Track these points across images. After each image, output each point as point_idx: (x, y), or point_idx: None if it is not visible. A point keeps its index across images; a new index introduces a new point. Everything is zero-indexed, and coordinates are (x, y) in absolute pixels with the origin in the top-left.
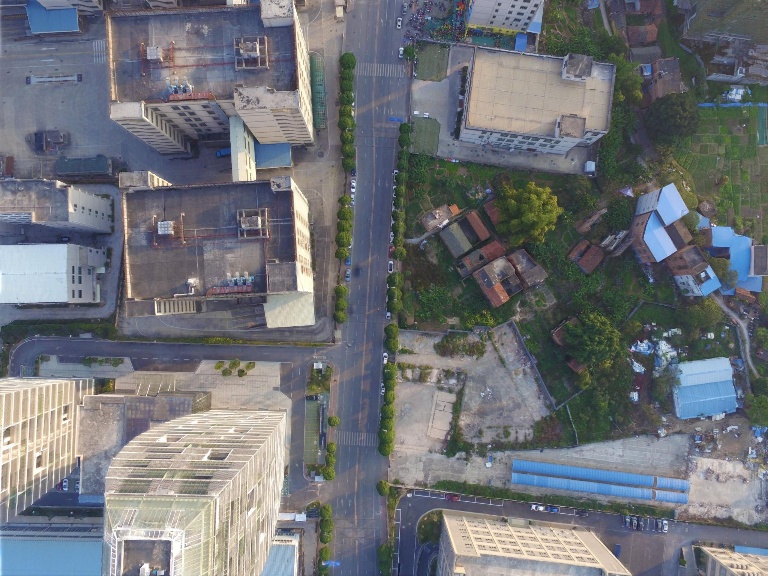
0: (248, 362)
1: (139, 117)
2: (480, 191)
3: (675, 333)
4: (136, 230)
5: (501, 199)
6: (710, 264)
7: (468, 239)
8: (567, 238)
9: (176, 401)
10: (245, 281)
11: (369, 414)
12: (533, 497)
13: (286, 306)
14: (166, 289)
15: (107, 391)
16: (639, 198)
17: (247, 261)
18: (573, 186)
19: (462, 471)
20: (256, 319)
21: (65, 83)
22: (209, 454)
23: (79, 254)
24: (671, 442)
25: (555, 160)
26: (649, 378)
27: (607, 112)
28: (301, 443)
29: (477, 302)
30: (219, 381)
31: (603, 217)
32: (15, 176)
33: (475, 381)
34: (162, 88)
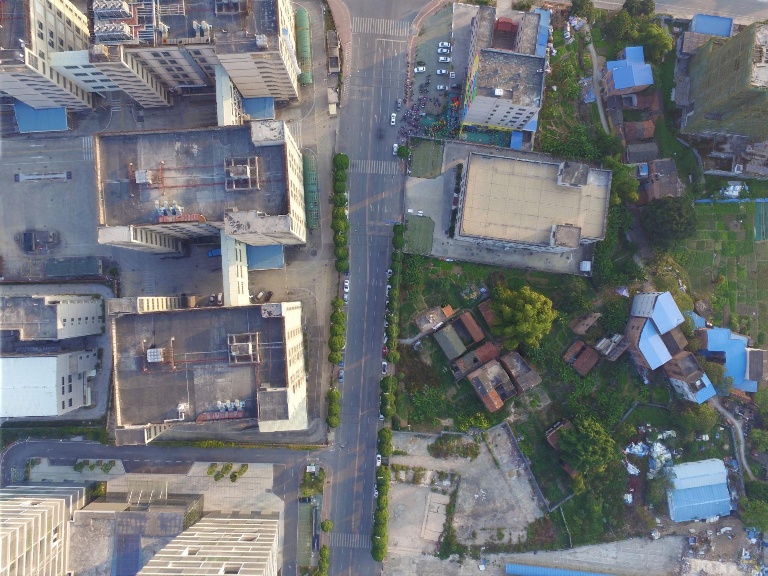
0: (241, 464)
1: (128, 241)
2: (474, 290)
3: (670, 436)
4: (125, 355)
5: (496, 301)
6: (705, 370)
7: (462, 340)
8: (562, 337)
9: (167, 517)
10: (236, 406)
11: (362, 516)
12: None
13: None
14: (156, 414)
15: (98, 496)
16: (635, 297)
17: (238, 385)
18: (568, 287)
19: (455, 573)
20: (249, 420)
21: (54, 181)
22: None
23: (69, 362)
24: (665, 544)
25: (550, 258)
26: (643, 480)
27: (603, 219)
28: (294, 545)
29: (471, 405)
30: (211, 483)
31: (598, 319)
32: (4, 276)
33: (469, 483)
34: (151, 209)
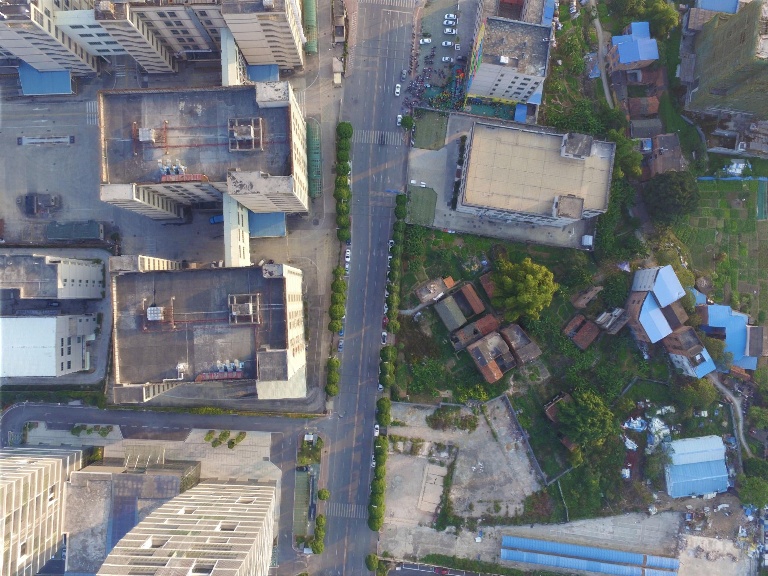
0: (238, 432)
1: (130, 199)
2: (476, 263)
3: (668, 411)
4: (125, 313)
5: (497, 273)
6: (705, 345)
7: (463, 311)
8: (562, 311)
9: (164, 479)
10: (235, 367)
11: (359, 486)
12: (522, 573)
13: None
14: (155, 373)
15: (95, 460)
16: (636, 273)
17: (238, 346)
18: (570, 261)
19: (452, 545)
20: (247, 388)
21: (57, 145)
22: (194, 566)
23: (68, 325)
24: (662, 519)
25: (552, 232)
26: (641, 455)
27: (606, 191)
28: (290, 514)
29: (470, 376)
30: (209, 450)
31: (599, 293)
32: (5, 239)
33: (467, 455)
34: (154, 168)
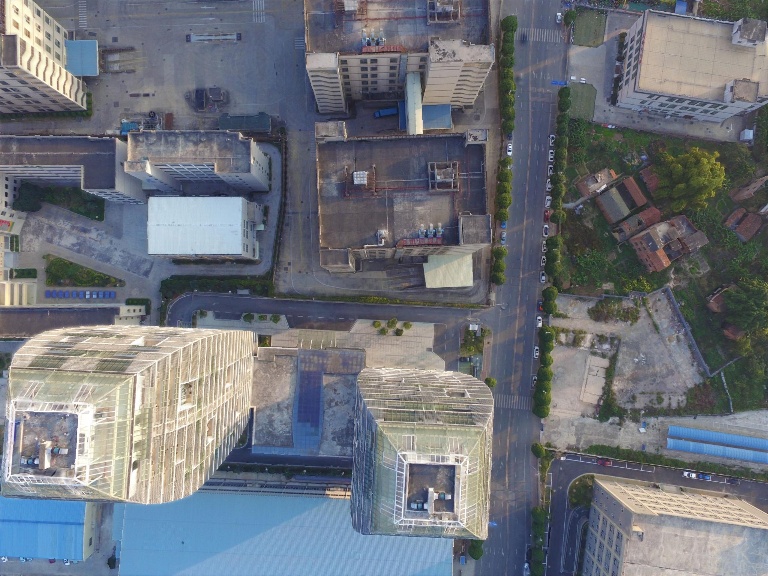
0: (402, 322)
1: (334, 68)
2: (635, 157)
3: None
4: (327, 180)
5: (660, 165)
6: None
7: None
8: (721, 206)
9: (349, 355)
10: (435, 233)
11: (522, 377)
12: (686, 464)
13: (445, 266)
14: (356, 240)
15: None
16: None
17: (436, 214)
18: (732, 154)
19: (615, 436)
20: (410, 280)
21: (224, 42)
22: None
23: (247, 209)
24: None
25: (711, 128)
26: None
27: None
28: None
29: (634, 267)
30: (373, 341)
31: None
32: None
33: (629, 347)
34: (354, 40)
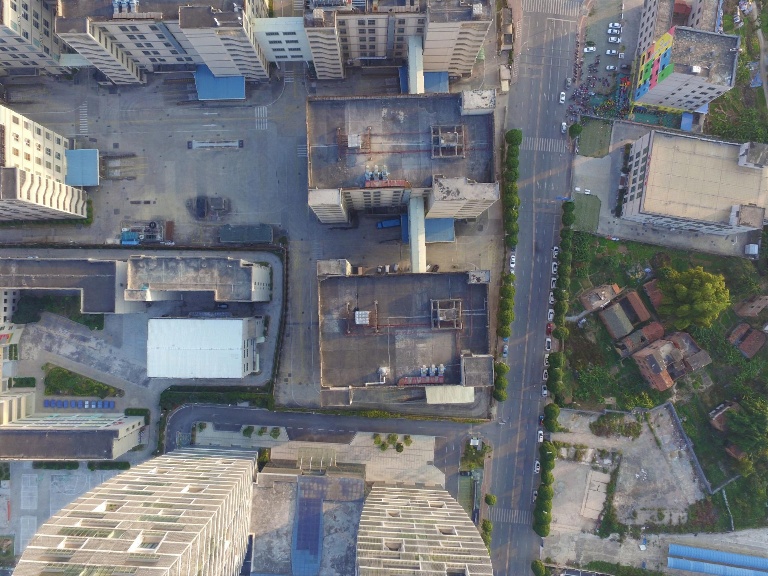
0: (403, 435)
1: (337, 204)
2: (639, 270)
3: None
4: (329, 317)
5: (664, 280)
6: None
7: None
8: (725, 320)
9: (349, 482)
10: (437, 372)
11: (522, 491)
12: None
13: None
14: (357, 377)
15: (266, 462)
16: None
17: (439, 351)
18: (736, 269)
19: (615, 553)
20: (411, 392)
21: (226, 149)
22: None
23: (247, 327)
24: None
25: (715, 241)
26: None
27: None
28: None
29: (637, 384)
30: (374, 453)
31: None
32: (175, 241)
33: (630, 462)
34: (357, 174)
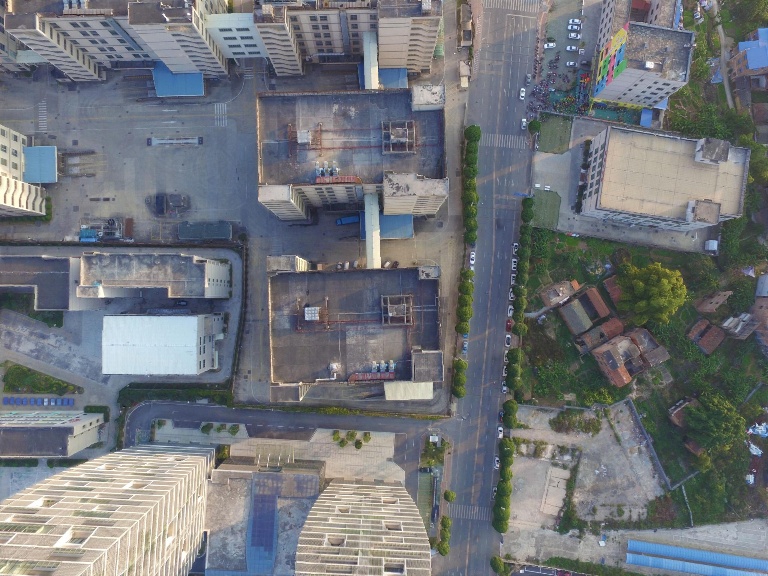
0: (363, 432)
1: (287, 200)
2: (599, 266)
3: None
4: (279, 313)
5: (623, 277)
6: None
7: None
8: (685, 316)
9: (304, 478)
10: (388, 368)
11: (482, 488)
12: None
13: None
14: (308, 373)
15: (224, 459)
16: (760, 278)
17: (389, 347)
18: (696, 265)
19: (575, 549)
20: (371, 389)
21: (186, 145)
22: (383, 565)
23: (204, 324)
24: None
25: (675, 237)
26: (765, 461)
27: (739, 196)
28: None
29: (596, 380)
30: (333, 450)
31: None
32: (134, 238)
33: (590, 458)
34: (308, 170)
